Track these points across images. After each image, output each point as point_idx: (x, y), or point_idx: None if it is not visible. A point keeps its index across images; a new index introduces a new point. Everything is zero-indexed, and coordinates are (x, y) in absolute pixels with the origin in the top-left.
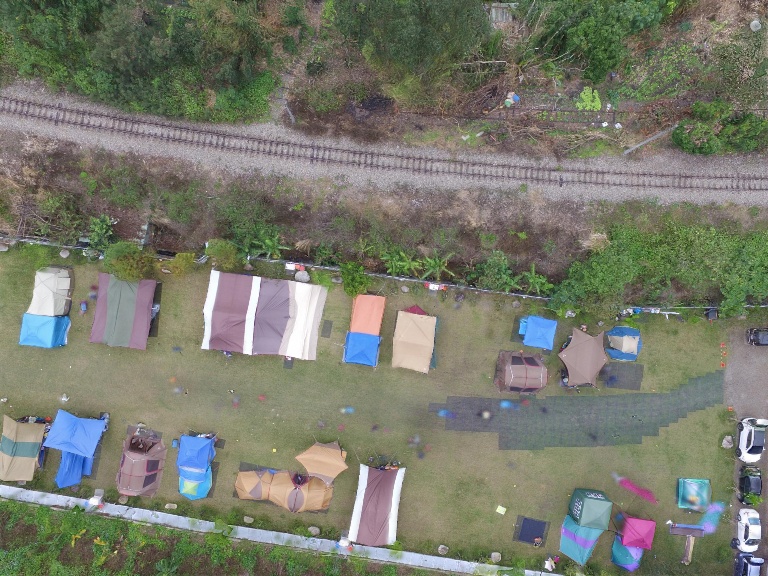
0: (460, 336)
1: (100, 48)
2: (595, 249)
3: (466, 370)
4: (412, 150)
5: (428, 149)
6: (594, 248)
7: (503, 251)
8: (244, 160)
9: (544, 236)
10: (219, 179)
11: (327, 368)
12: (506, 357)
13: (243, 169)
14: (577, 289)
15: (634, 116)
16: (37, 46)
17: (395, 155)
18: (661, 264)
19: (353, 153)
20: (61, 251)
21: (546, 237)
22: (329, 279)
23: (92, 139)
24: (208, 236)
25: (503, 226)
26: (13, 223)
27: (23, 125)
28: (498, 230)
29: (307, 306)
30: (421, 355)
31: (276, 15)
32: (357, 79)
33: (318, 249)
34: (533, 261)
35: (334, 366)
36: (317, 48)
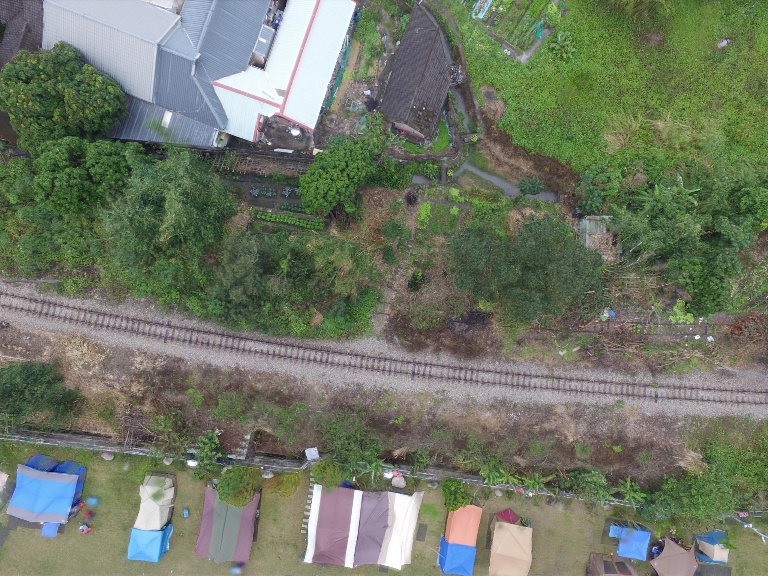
0: (552, 539)
1: (219, 287)
2: (693, 473)
3: (557, 572)
4: (511, 366)
5: (526, 365)
6: (692, 471)
7: (597, 462)
8: (347, 376)
9: (638, 449)
10: (322, 393)
11: (422, 571)
12: (598, 563)
13: (346, 384)
14: (673, 508)
15: (726, 329)
16: (155, 279)
17: (494, 371)
18: (754, 480)
19: (453, 369)
20: (165, 458)
21: (640, 450)
22: (424, 483)
23: (200, 355)
24: (308, 443)
25: (599, 440)
26: (117, 428)
27: (133, 342)
28: (593, 442)
29: (404, 513)
30: (518, 567)
31: (373, 219)
32: (456, 293)
33: (415, 456)
34: None
35: (428, 569)
36: (414, 254)
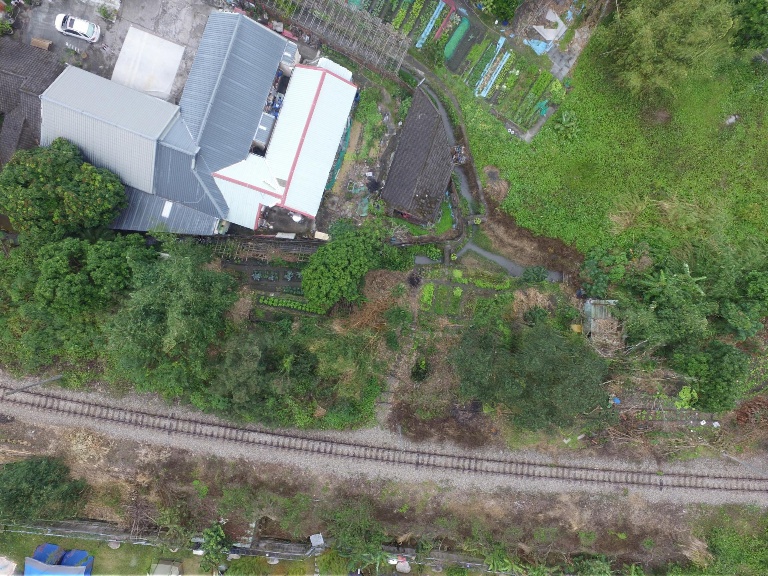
0: None
1: (222, 389)
2: (698, 564)
3: None
4: (515, 455)
5: (531, 453)
6: (697, 562)
7: (602, 548)
8: (351, 466)
9: (643, 536)
10: (326, 483)
11: None
12: None
13: (350, 473)
14: None
15: (732, 414)
16: None
17: (498, 460)
18: (759, 568)
19: (457, 458)
20: None
21: (645, 537)
22: (429, 568)
23: (204, 447)
24: (313, 530)
25: (603, 527)
26: (123, 515)
27: (138, 435)
28: (598, 529)
29: None
30: None
31: (376, 302)
32: None
33: (419, 541)
34: (633, 563)
35: None
36: (417, 339)
